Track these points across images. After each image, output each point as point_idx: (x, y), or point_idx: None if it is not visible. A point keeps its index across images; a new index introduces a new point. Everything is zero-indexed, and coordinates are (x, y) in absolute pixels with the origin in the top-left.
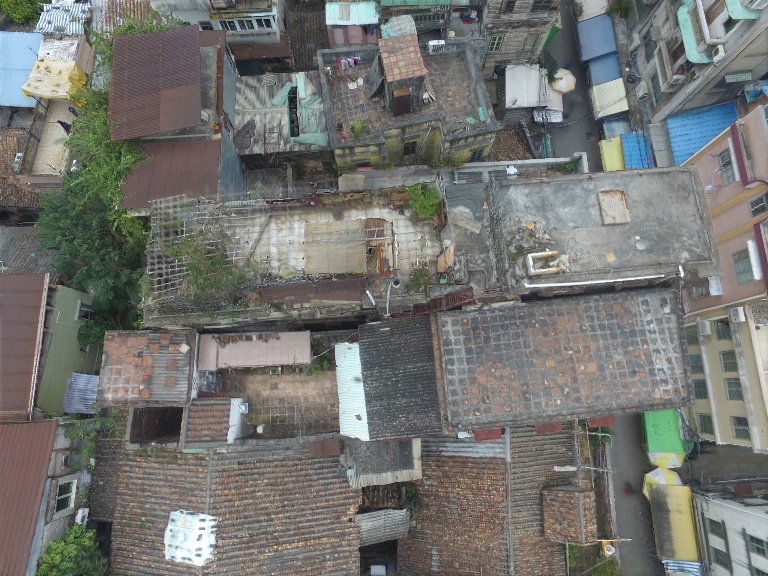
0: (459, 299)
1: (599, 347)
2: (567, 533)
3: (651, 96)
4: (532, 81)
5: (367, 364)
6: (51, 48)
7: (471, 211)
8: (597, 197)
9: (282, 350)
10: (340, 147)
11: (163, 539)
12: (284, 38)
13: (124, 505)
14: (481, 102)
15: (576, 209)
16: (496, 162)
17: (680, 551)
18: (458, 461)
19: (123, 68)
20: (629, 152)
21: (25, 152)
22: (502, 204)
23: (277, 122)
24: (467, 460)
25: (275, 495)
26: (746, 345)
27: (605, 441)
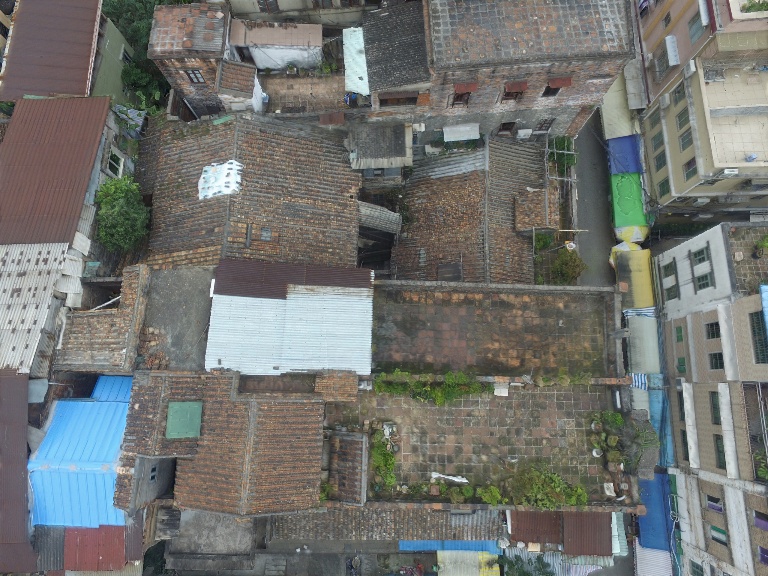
0: None
1: (559, 15)
2: (534, 222)
3: None
4: None
5: (369, 40)
6: None
7: None
8: None
9: (299, 36)
10: None
11: (197, 187)
12: None
13: (163, 177)
14: None
15: None
16: None
17: (639, 301)
18: (444, 180)
19: None
20: None
21: None
22: None
23: None
24: (452, 178)
25: (290, 162)
26: (696, 94)
27: (571, 163)
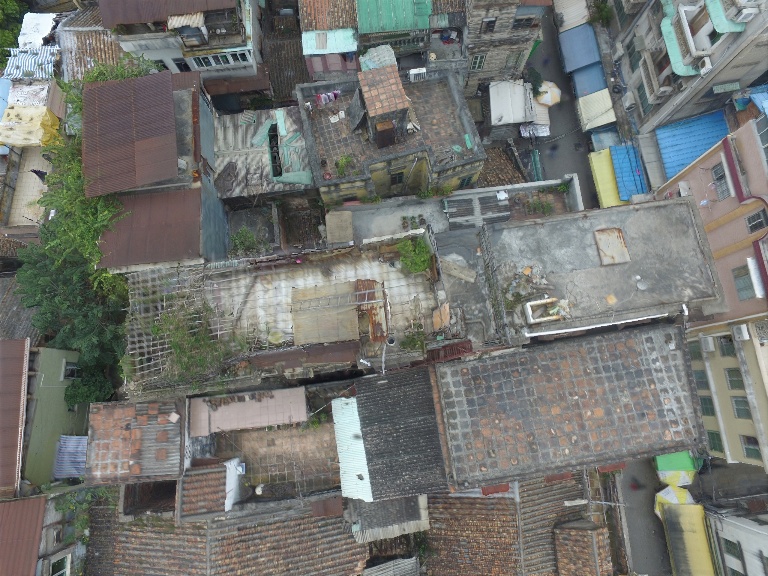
0: (457, 351)
1: (605, 390)
2: (582, 573)
3: (638, 106)
4: (517, 97)
5: (366, 420)
6: (21, 94)
7: (464, 259)
8: (594, 236)
9: (277, 409)
10: (325, 185)
11: None
12: (261, 70)
13: None
14: (467, 129)
15: (573, 250)
16: (486, 188)
17: (696, 572)
18: (466, 502)
19: (94, 120)
20: (619, 164)
21: (0, 203)
22: (496, 249)
23: (258, 162)
24: (475, 501)
25: (279, 559)
26: (752, 363)
27: (615, 472)
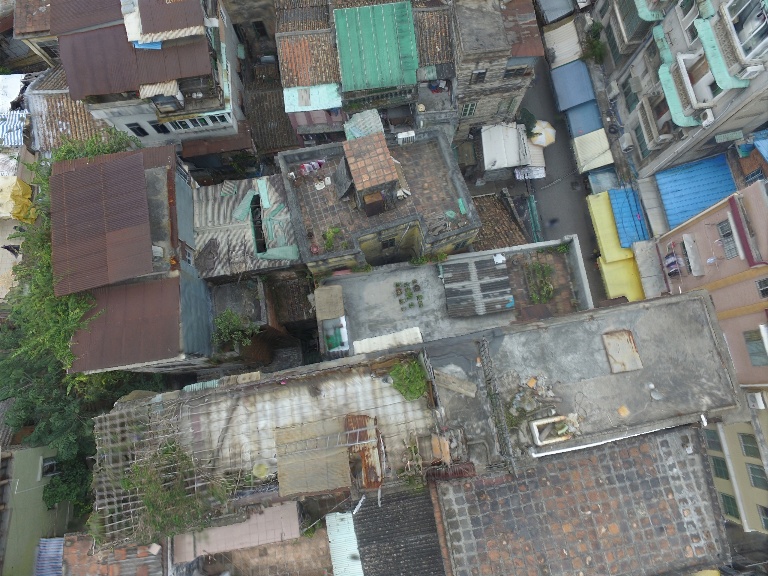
0: (459, 471)
1: (619, 503)
2: None
3: (636, 148)
4: (510, 140)
5: (363, 538)
6: None
7: (463, 370)
8: (602, 340)
9: (267, 526)
10: (312, 261)
11: None
12: (242, 128)
13: None
14: (460, 193)
15: (580, 356)
16: (482, 252)
17: None
18: None
19: (62, 209)
20: (619, 209)
21: None
22: (497, 358)
23: (241, 238)
24: None
25: None
26: (767, 433)
27: None
